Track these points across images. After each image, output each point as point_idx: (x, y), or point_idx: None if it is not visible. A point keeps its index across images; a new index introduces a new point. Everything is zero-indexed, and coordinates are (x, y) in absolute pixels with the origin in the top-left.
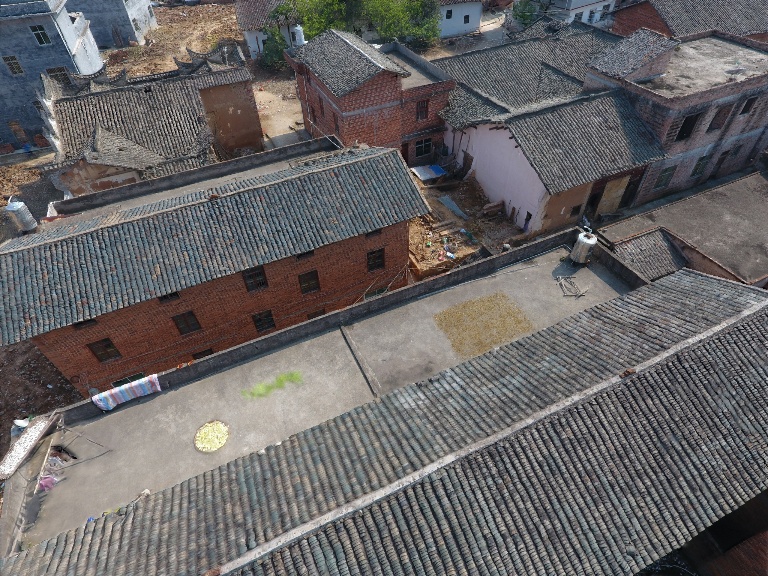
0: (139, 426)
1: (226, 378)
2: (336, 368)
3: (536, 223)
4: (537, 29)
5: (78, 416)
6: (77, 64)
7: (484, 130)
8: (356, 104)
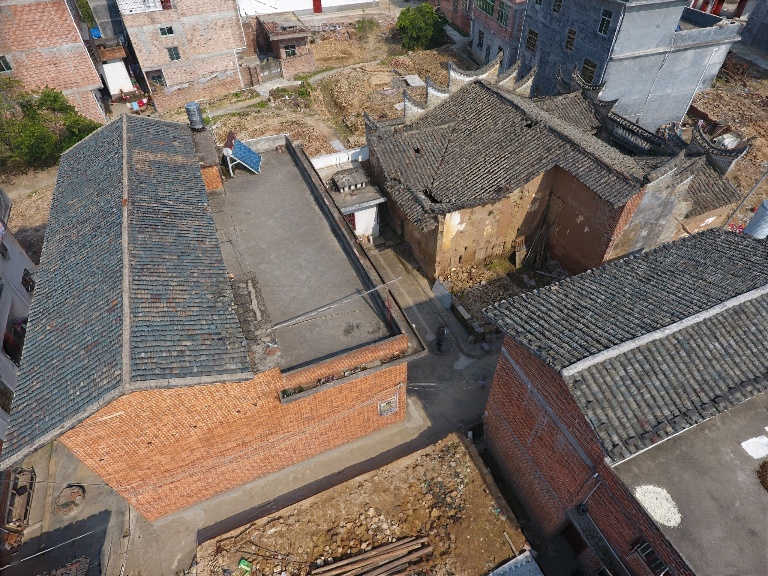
0: None
1: None
2: None
3: None
4: None
5: None
6: (609, 69)
7: None
8: (524, 361)
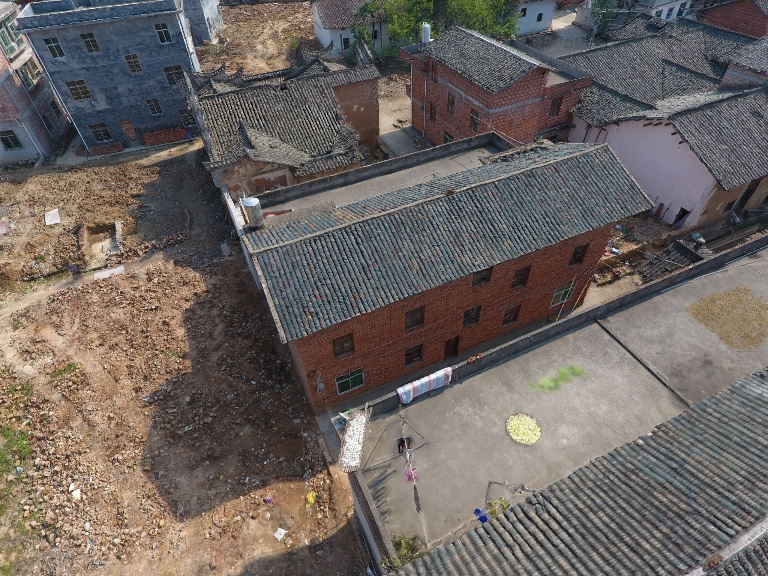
0: (443, 419)
1: (507, 371)
2: (614, 361)
3: (694, 219)
4: (636, 26)
5: (380, 409)
6: (193, 62)
7: (630, 126)
8: (503, 101)
